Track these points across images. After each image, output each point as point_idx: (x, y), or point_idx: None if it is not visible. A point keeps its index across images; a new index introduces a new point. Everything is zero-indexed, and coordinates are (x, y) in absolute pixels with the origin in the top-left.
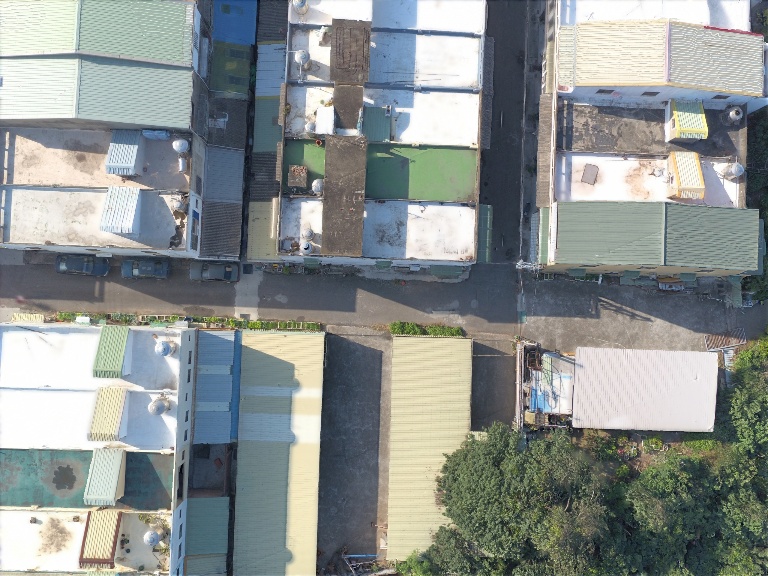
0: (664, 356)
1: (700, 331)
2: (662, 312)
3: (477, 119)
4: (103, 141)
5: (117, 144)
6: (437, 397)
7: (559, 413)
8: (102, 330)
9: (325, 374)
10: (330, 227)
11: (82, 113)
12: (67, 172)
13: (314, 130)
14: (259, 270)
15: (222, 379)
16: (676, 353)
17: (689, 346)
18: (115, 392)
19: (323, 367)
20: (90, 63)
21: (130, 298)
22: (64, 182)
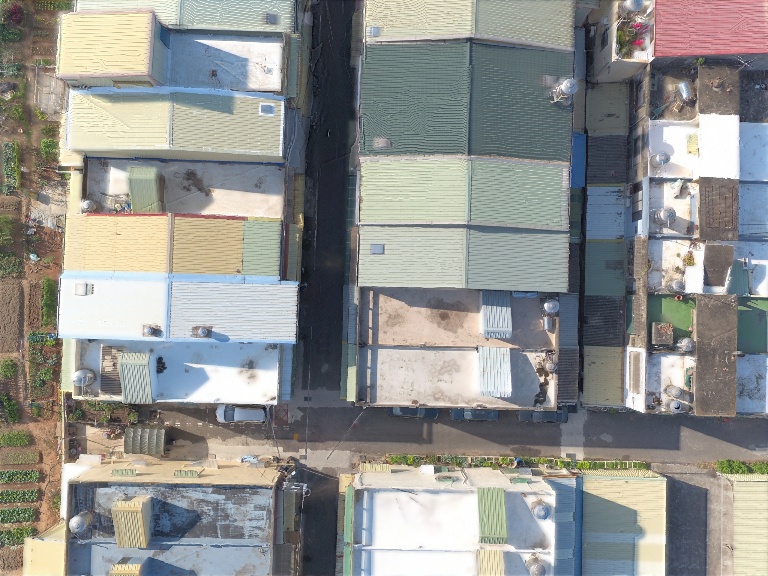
0: None
1: None
2: None
3: None
4: (465, 299)
5: (490, 306)
6: None
7: None
8: (478, 492)
9: None
10: (704, 388)
11: (471, 283)
12: (431, 331)
13: (683, 289)
14: (583, 409)
15: (566, 526)
16: None
17: None
18: (492, 554)
19: None
20: (477, 232)
21: (458, 439)
22: (428, 341)
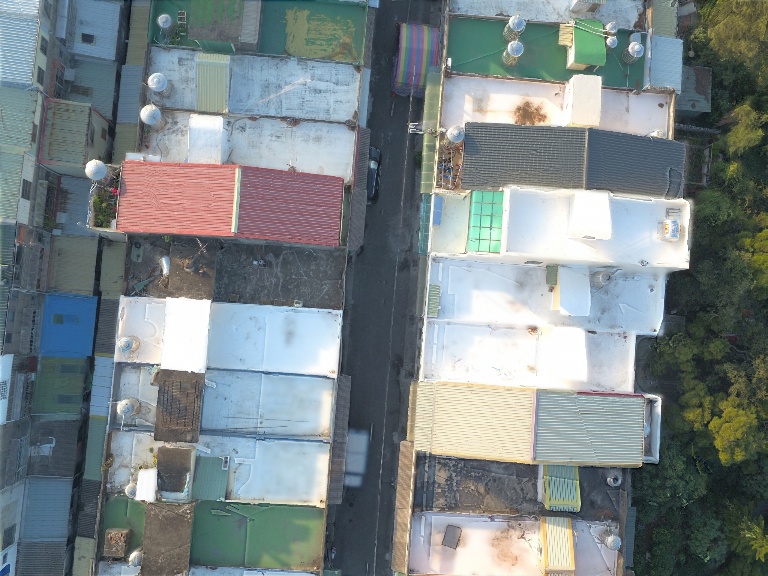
0: None
1: None
2: None
3: (327, 472)
4: None
5: None
6: None
7: None
8: None
9: None
10: None
11: None
12: None
13: (134, 495)
14: None
15: None
16: None
17: None
18: None
19: None
20: None
21: None
22: None
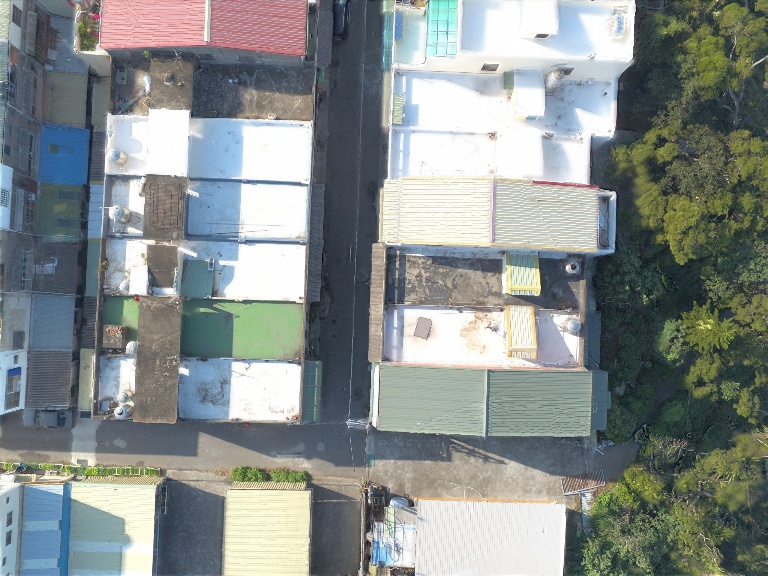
0: (509, 509)
1: (556, 474)
2: (516, 454)
3: None
4: None
5: None
6: (273, 552)
7: (401, 567)
8: None
9: (165, 521)
10: (143, 393)
11: None
12: None
13: (128, 290)
14: None
15: (50, 535)
16: (522, 505)
17: (544, 489)
18: None
19: (154, 522)
20: None
21: None
22: None
